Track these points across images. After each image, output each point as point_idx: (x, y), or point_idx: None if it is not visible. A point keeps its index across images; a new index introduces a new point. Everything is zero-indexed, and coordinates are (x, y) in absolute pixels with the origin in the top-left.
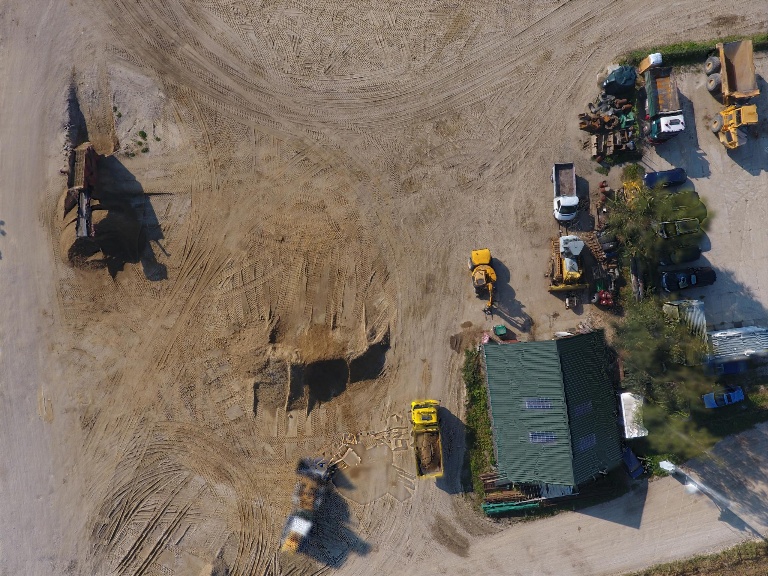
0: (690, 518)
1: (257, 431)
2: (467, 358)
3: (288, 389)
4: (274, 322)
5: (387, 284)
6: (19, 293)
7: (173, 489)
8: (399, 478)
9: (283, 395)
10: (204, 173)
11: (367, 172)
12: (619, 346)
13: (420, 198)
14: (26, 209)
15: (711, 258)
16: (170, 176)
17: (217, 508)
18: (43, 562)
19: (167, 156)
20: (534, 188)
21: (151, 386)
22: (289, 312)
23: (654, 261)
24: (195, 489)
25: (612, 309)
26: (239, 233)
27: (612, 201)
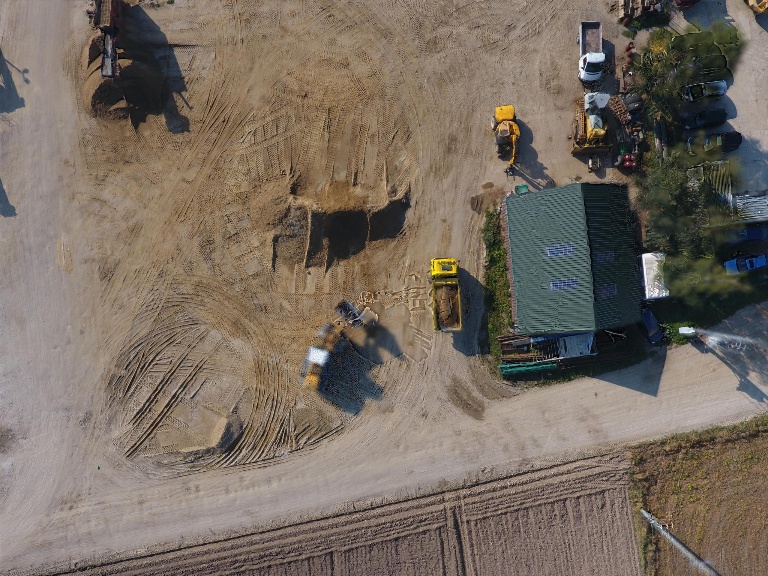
0: (708, 387)
1: (275, 287)
2: (488, 219)
3: (307, 242)
4: (295, 177)
5: (409, 143)
6: (41, 141)
7: (189, 343)
8: (416, 338)
9: (302, 250)
10: (229, 26)
11: (392, 30)
12: (641, 211)
13: (444, 58)
14: (50, 58)
15: (736, 125)
16: (195, 28)
17: (233, 363)
18: (58, 413)
19: (192, 8)
20: (559, 50)
21: (170, 239)
22: (310, 168)
23: (679, 126)
24: (211, 344)
25: (635, 174)
26: (262, 88)
27: (638, 65)
